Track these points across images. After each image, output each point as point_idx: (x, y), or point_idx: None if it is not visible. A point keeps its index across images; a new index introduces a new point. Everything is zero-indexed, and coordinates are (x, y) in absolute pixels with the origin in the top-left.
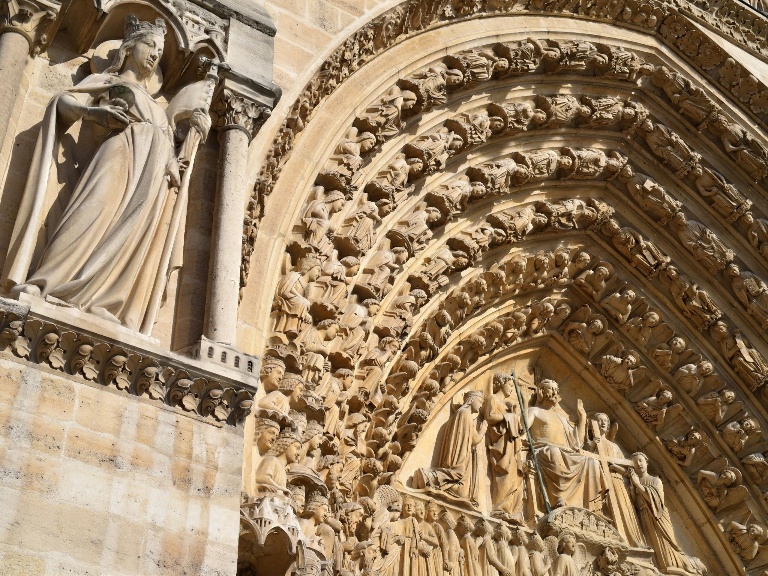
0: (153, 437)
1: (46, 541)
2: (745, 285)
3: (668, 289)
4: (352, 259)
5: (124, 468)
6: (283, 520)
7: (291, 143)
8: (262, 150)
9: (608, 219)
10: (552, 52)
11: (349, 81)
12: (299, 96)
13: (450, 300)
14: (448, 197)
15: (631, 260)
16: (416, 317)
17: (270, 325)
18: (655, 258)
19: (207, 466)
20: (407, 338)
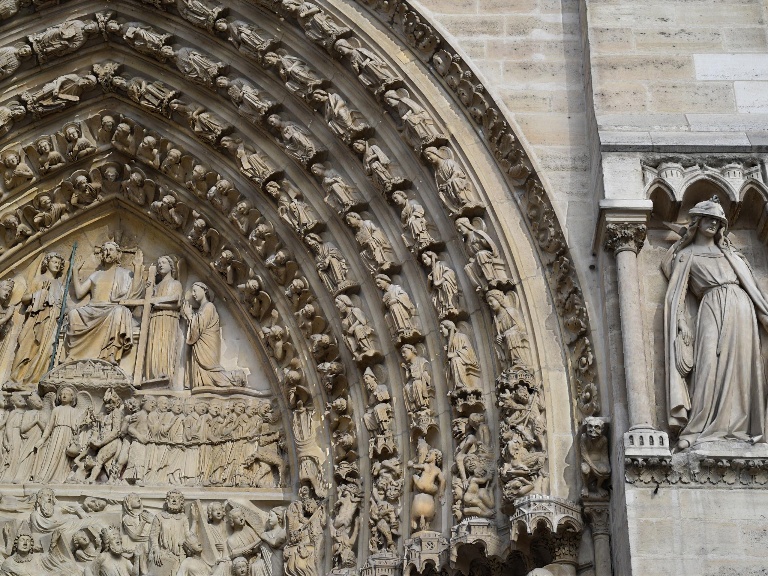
0: None
1: None
2: (230, 95)
3: None
4: None
5: None
6: None
7: None
8: None
9: (111, 78)
10: None
11: None
12: None
13: None
14: None
15: None
16: None
17: None
18: (158, 98)
19: None
20: None
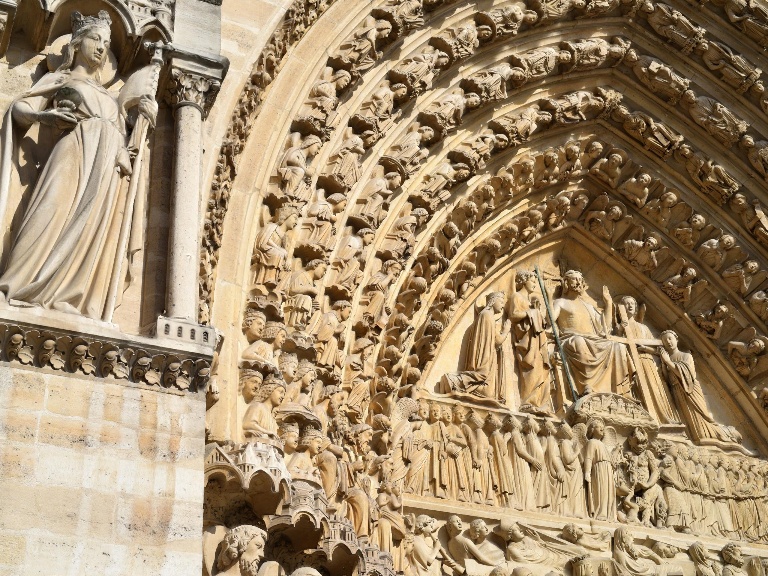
0: (120, 414)
1: (26, 520)
2: (760, 155)
3: (684, 167)
4: (338, 196)
5: (94, 446)
6: (265, 463)
7: (259, 98)
8: (227, 113)
9: (616, 106)
10: None
11: (320, 21)
12: (262, 51)
13: (457, 211)
14: (440, 114)
15: (644, 143)
16: (423, 233)
17: (251, 278)
18: (667, 139)
19: (171, 433)
20: (415, 255)
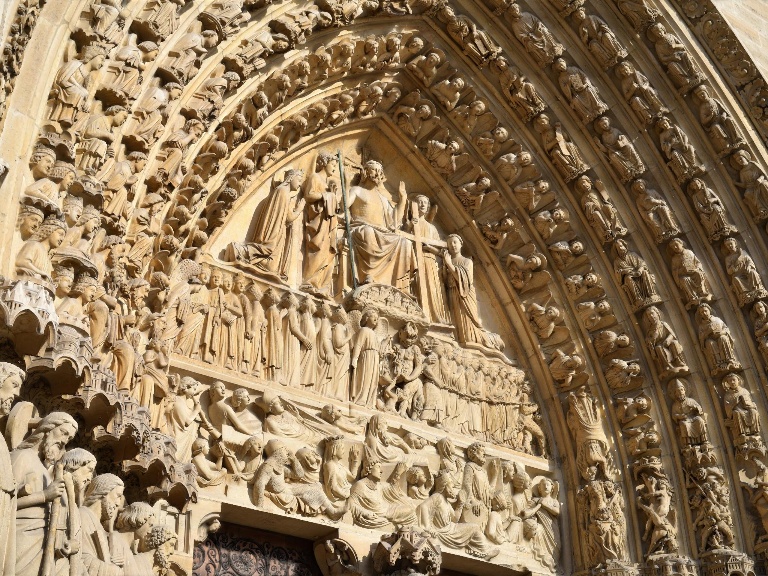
0: None
1: None
2: (570, 80)
3: (498, 79)
4: (150, 44)
5: None
6: (34, 303)
7: None
8: None
9: (444, 6)
10: None
11: None
12: None
13: (270, 82)
14: None
15: (463, 48)
16: (232, 98)
17: (46, 113)
18: (486, 48)
19: None
20: (221, 118)
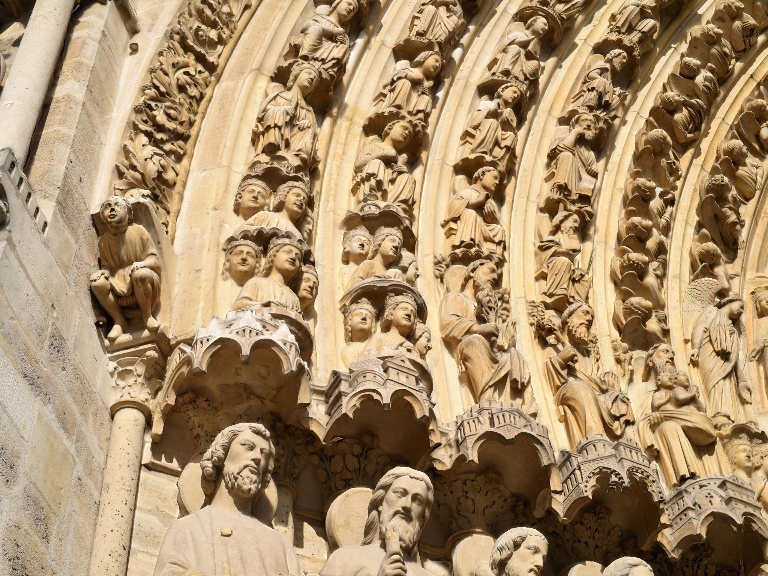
0: None
1: None
2: None
3: None
4: (421, 55)
5: None
6: None
7: None
8: (175, 4)
9: None
10: None
11: None
12: None
13: (692, 45)
14: None
15: None
16: (647, 87)
17: None
18: None
19: None
20: (645, 114)
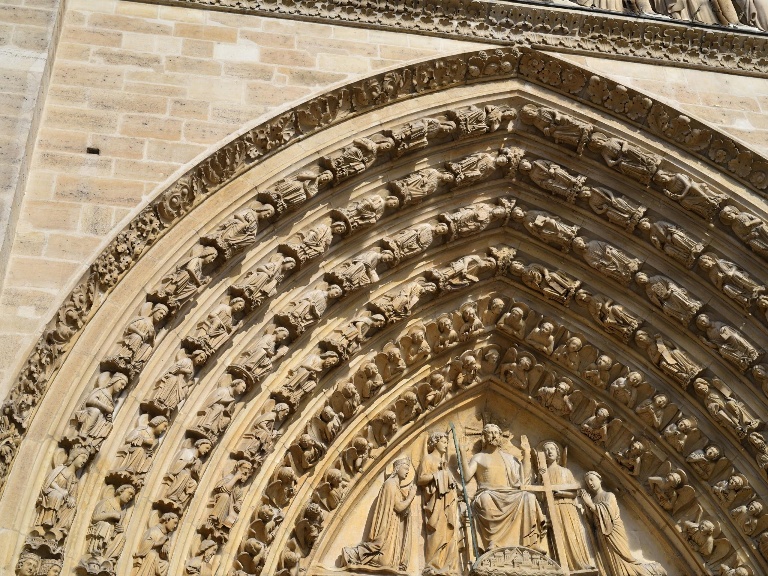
0: None
1: None
2: (653, 291)
3: (588, 310)
4: (157, 419)
5: None
6: None
7: (55, 353)
8: (12, 376)
9: (510, 263)
10: (384, 144)
11: (141, 262)
12: (59, 310)
13: (335, 395)
14: (293, 314)
15: (543, 294)
16: (296, 422)
17: (34, 520)
18: (563, 287)
19: None
20: (288, 445)
